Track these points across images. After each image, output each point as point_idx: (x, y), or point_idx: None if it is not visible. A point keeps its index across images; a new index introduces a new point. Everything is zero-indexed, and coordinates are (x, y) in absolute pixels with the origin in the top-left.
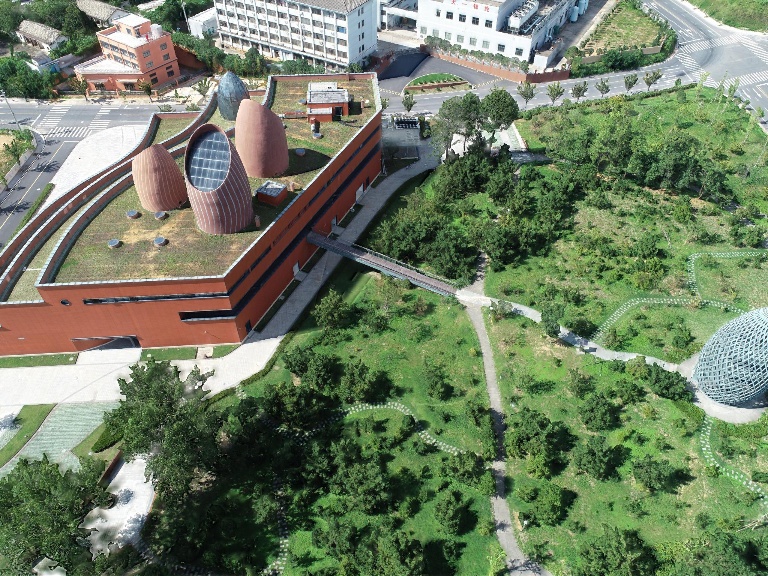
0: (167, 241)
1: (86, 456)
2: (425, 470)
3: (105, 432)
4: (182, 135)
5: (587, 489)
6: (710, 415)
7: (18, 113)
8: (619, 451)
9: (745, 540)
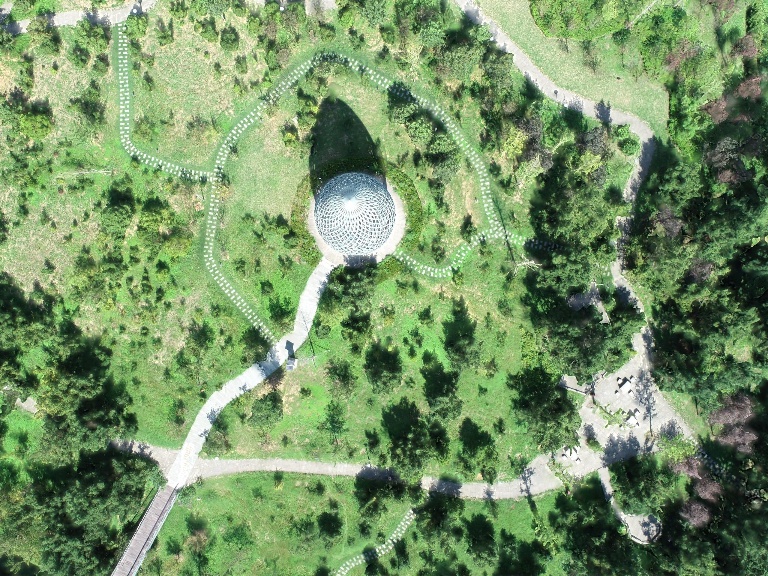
0: None
1: None
2: (424, 556)
3: None
4: None
5: (463, 406)
6: (393, 251)
7: None
8: (432, 368)
9: (524, 276)
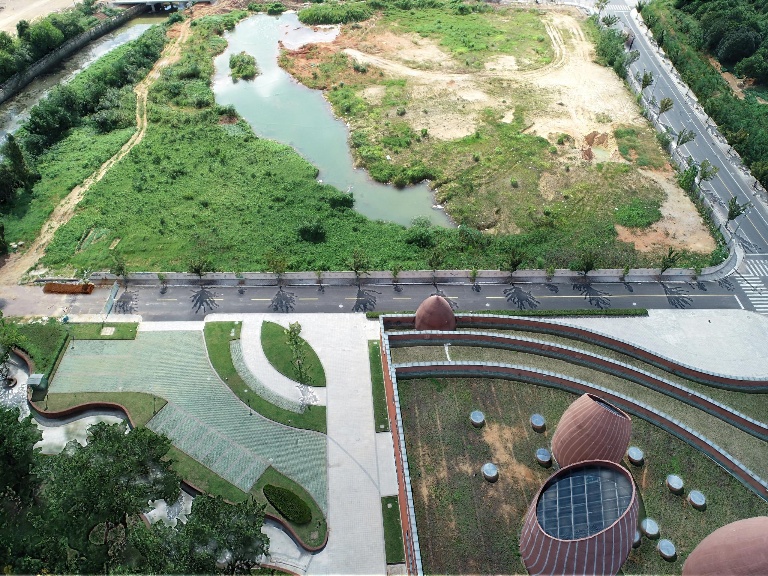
0: (494, 480)
1: (262, 482)
2: None
3: (285, 491)
4: (767, 431)
5: None
6: None
7: (762, 235)
8: None
9: None
